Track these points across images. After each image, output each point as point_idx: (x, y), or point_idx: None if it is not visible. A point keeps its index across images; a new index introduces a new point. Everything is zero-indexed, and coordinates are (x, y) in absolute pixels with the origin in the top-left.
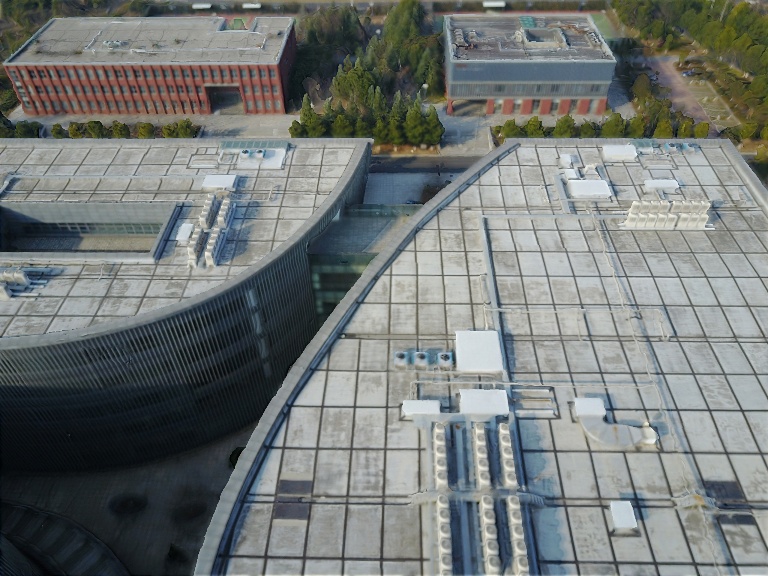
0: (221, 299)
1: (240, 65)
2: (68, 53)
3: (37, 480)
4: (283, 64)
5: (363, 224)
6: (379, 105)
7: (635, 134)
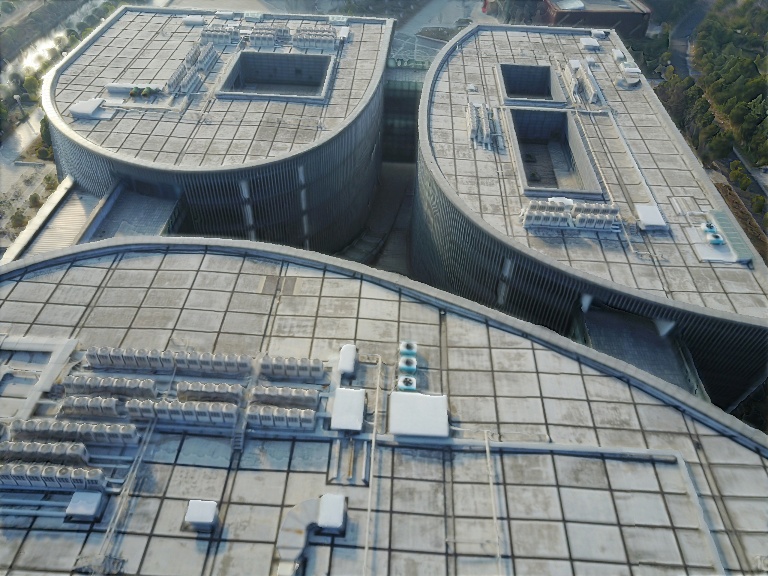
0: (484, 236)
1: None
2: None
3: (404, 247)
4: None
5: (663, 360)
6: None
7: None
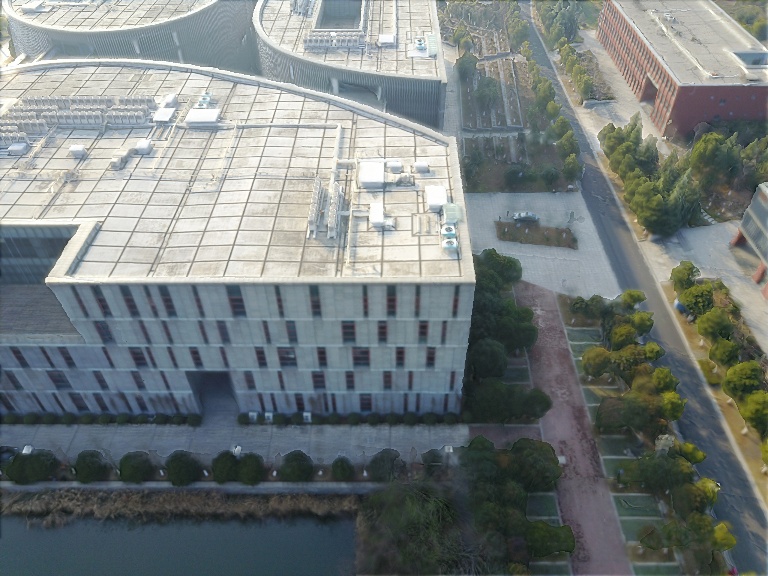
0: (277, 54)
1: (666, 71)
2: (641, 7)
3: None
4: (708, 100)
5: None
6: (666, 165)
7: (743, 408)
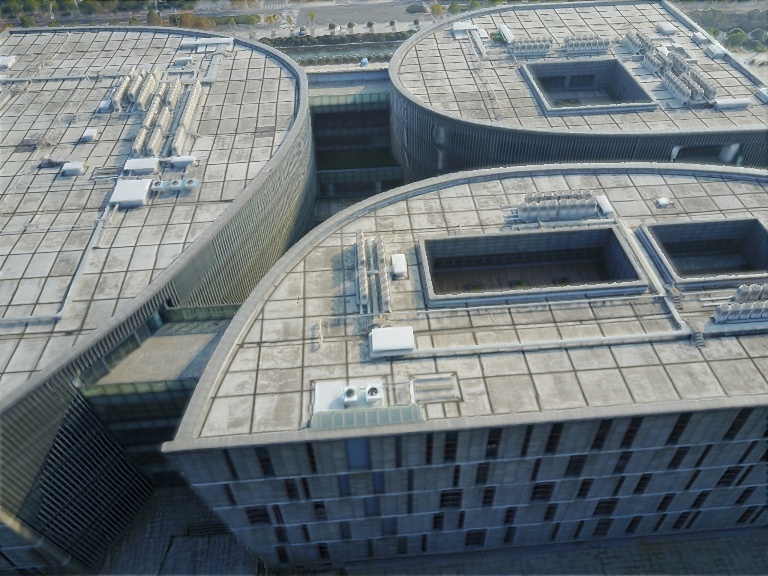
0: None
1: None
2: None
3: None
4: None
5: None
6: None
7: None
